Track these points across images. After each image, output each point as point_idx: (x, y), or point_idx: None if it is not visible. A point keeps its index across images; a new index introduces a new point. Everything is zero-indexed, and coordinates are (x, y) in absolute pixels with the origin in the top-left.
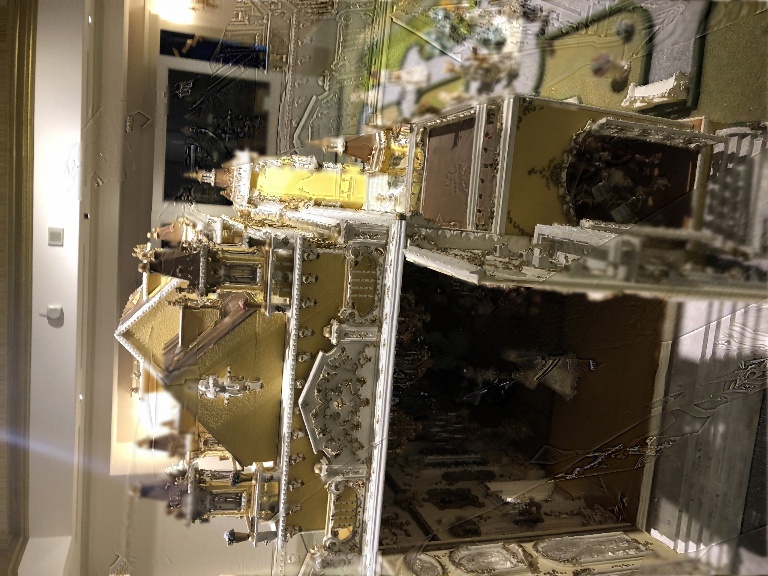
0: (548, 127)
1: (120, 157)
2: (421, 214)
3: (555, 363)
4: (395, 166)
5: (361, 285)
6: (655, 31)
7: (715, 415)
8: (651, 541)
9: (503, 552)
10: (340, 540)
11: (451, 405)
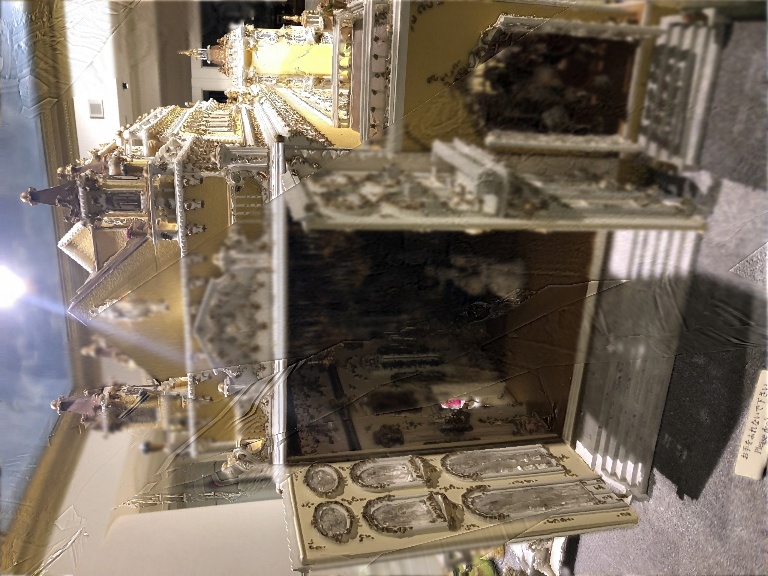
0: (450, 25)
1: None
2: (301, 134)
3: (142, 400)
4: None
5: (247, 210)
6: (58, 71)
7: None
8: (569, 454)
9: (408, 465)
10: None
11: None
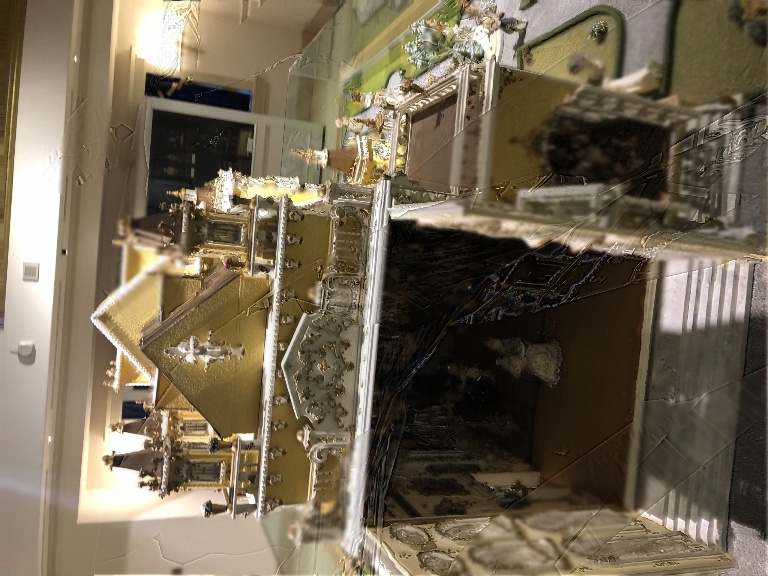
0: None
1: (103, 150)
2: None
3: (549, 177)
4: (377, 179)
5: None
6: None
7: (699, 385)
8: (639, 519)
9: None
10: (336, 312)
11: (447, 202)
